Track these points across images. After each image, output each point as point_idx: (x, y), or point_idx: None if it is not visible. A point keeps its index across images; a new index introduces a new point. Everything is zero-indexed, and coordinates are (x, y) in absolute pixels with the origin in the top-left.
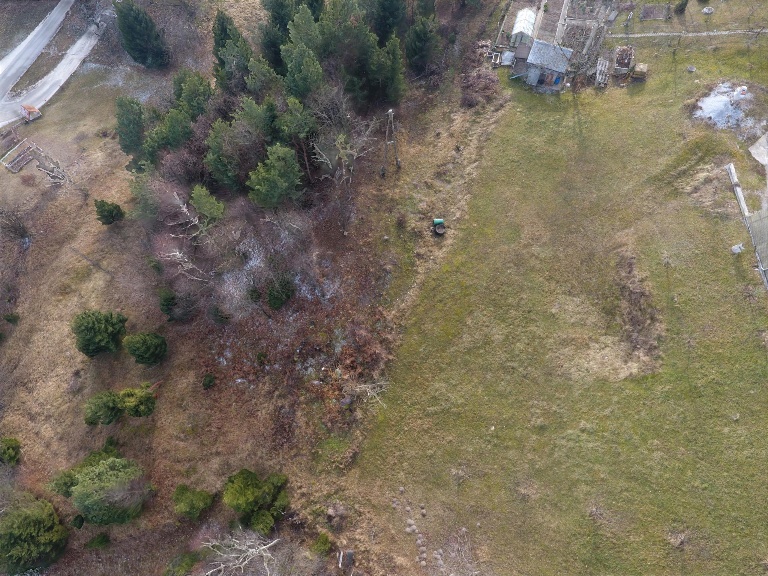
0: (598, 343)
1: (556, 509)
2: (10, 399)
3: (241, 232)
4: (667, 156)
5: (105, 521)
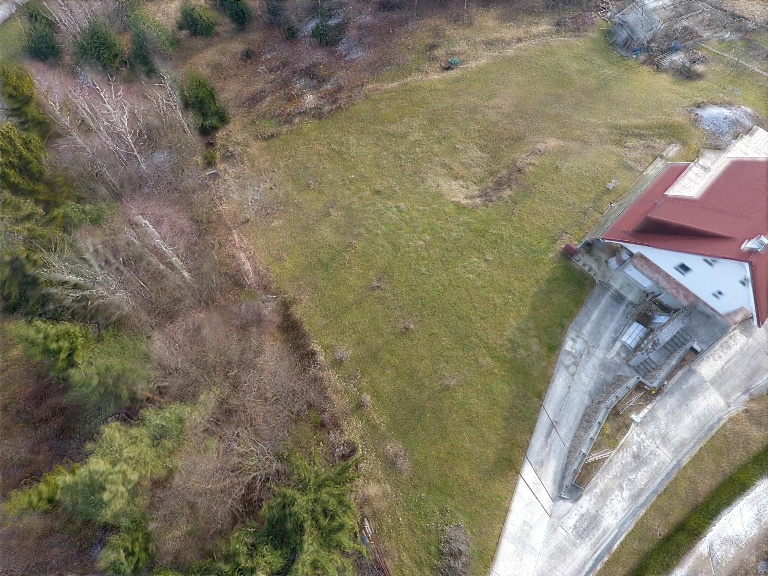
0: (464, 182)
1: (336, 229)
2: (154, 4)
3: (342, 5)
4: (638, 118)
5: (133, 68)
